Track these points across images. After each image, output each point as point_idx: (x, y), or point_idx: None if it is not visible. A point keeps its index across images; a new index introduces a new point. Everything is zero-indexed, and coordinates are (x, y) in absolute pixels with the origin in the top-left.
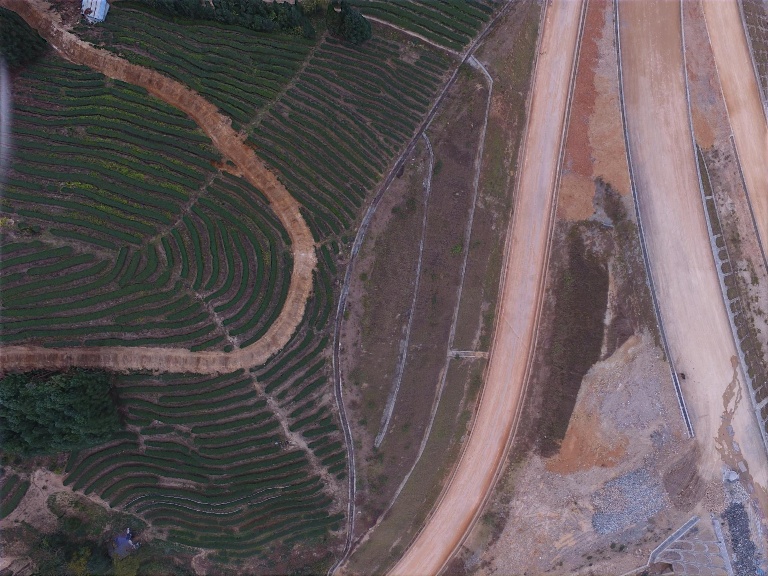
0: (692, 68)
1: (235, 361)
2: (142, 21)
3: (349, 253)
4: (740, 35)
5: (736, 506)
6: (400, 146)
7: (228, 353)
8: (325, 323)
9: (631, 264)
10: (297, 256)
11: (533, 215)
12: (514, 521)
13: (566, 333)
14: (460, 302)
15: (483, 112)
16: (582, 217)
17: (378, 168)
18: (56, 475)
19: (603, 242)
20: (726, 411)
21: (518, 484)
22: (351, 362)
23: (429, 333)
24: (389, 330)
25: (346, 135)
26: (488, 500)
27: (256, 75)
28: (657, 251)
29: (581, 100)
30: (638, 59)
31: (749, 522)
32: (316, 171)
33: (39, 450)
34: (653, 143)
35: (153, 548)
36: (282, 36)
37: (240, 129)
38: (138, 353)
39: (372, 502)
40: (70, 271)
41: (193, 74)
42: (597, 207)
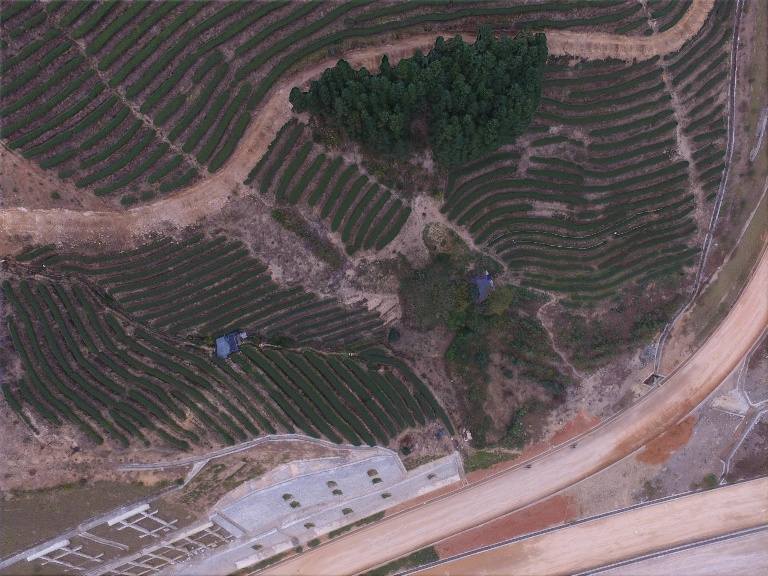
0: None
1: (650, 48)
2: None
3: None
4: None
5: None
6: None
7: (643, 41)
8: None
9: None
10: None
11: None
12: None
13: None
14: None
15: None
16: None
17: None
18: (434, 202)
19: None
20: None
21: None
22: (748, 57)
23: None
24: (766, 39)
25: None
26: None
27: None
28: None
29: None
30: None
31: None
32: None
33: (467, 138)
34: None
35: None
36: None
37: None
38: (560, 40)
39: (729, 233)
40: None
41: None
42: None
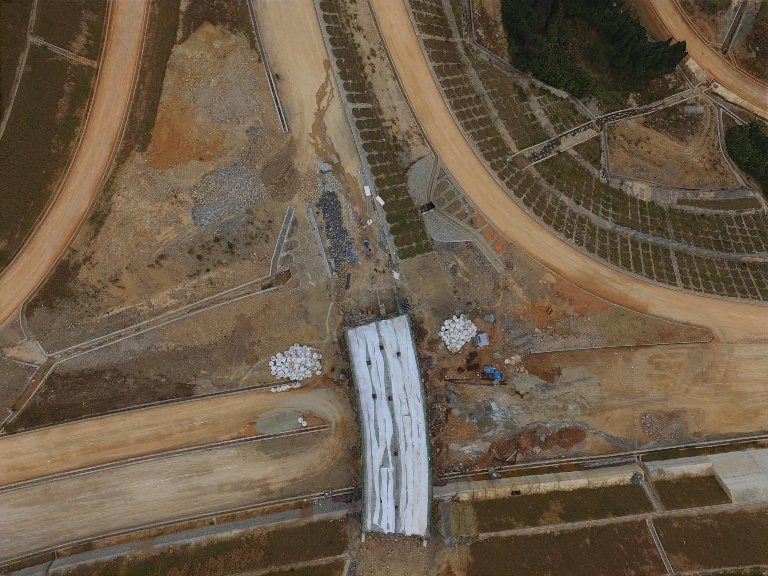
0: None
1: None
2: None
3: None
4: None
5: (327, 194)
6: None
7: None
8: None
9: None
10: None
11: None
12: (115, 216)
13: (161, 34)
14: None
15: None
16: None
17: None
18: None
19: None
20: (319, 108)
21: (120, 181)
22: None
23: None
24: None
25: None
26: (96, 202)
27: None
28: None
29: None
30: None
31: (341, 210)
32: None
33: None
34: None
35: None
36: None
37: None
38: None
39: None
40: None
41: None
42: None
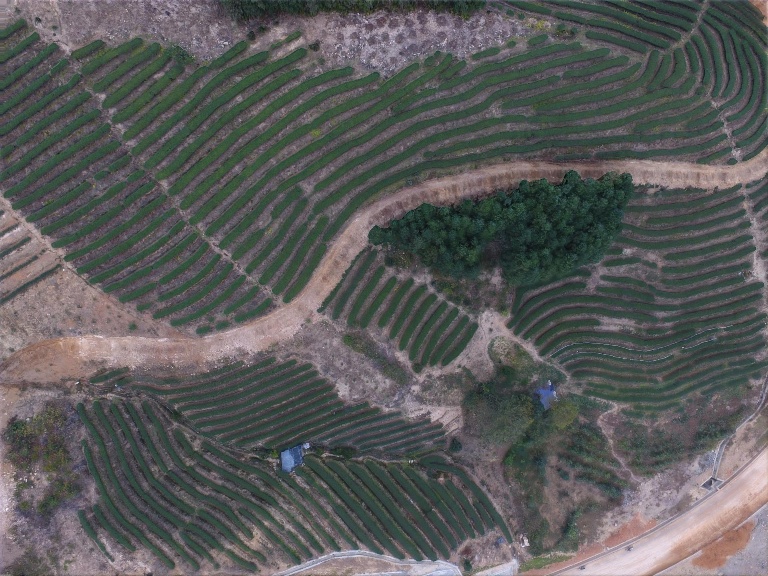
0: None
1: (733, 176)
2: None
3: None
4: None
5: None
6: None
7: (725, 169)
8: None
9: None
10: None
11: None
12: None
13: None
14: None
15: None
16: None
17: None
18: (500, 317)
19: None
20: None
21: None
22: None
23: None
24: None
25: None
26: None
27: None
28: None
29: None
30: None
31: None
32: None
33: (543, 268)
34: None
35: (568, 403)
36: None
37: None
38: (640, 168)
39: None
40: (600, 76)
41: None
42: None
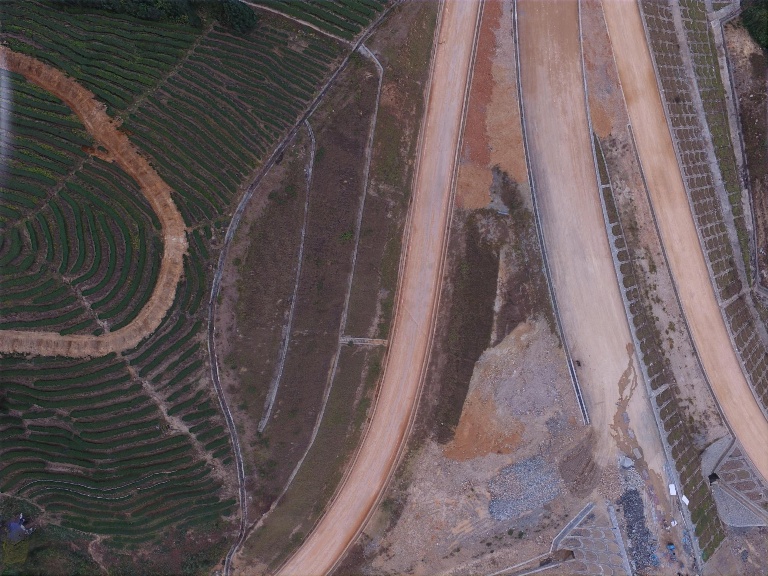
0: (589, 57)
1: (107, 345)
2: (32, 10)
3: (223, 238)
4: (638, 25)
5: (631, 492)
6: (281, 133)
7: (100, 337)
8: (198, 307)
9: (527, 252)
10: (169, 241)
11: (432, 204)
12: (411, 507)
13: (461, 320)
14: (351, 289)
15: (373, 100)
16: (479, 205)
17: (256, 154)
18: None
19: (498, 230)
20: (621, 398)
21: (415, 471)
22: (226, 346)
23: (316, 319)
24: (269, 315)
25: (225, 122)
26: (387, 487)
27: (138, 63)
28: (554, 239)
29: (479, 89)
30: (536, 49)
31: (644, 508)
32: (191, 157)
33: None
34: (550, 132)
35: (48, 533)
36: (169, 24)
37: (115, 115)
38: (9, 337)
39: (262, 487)
40: None
41: (74, 61)
42: (494, 195)
